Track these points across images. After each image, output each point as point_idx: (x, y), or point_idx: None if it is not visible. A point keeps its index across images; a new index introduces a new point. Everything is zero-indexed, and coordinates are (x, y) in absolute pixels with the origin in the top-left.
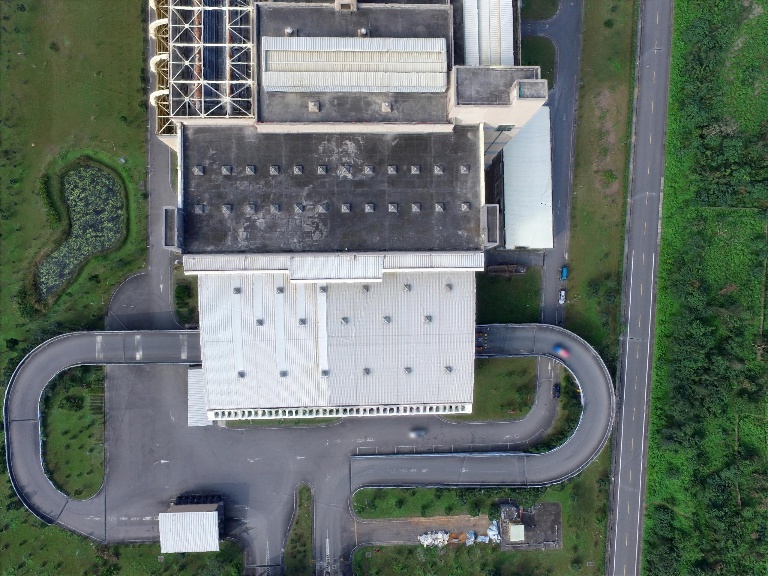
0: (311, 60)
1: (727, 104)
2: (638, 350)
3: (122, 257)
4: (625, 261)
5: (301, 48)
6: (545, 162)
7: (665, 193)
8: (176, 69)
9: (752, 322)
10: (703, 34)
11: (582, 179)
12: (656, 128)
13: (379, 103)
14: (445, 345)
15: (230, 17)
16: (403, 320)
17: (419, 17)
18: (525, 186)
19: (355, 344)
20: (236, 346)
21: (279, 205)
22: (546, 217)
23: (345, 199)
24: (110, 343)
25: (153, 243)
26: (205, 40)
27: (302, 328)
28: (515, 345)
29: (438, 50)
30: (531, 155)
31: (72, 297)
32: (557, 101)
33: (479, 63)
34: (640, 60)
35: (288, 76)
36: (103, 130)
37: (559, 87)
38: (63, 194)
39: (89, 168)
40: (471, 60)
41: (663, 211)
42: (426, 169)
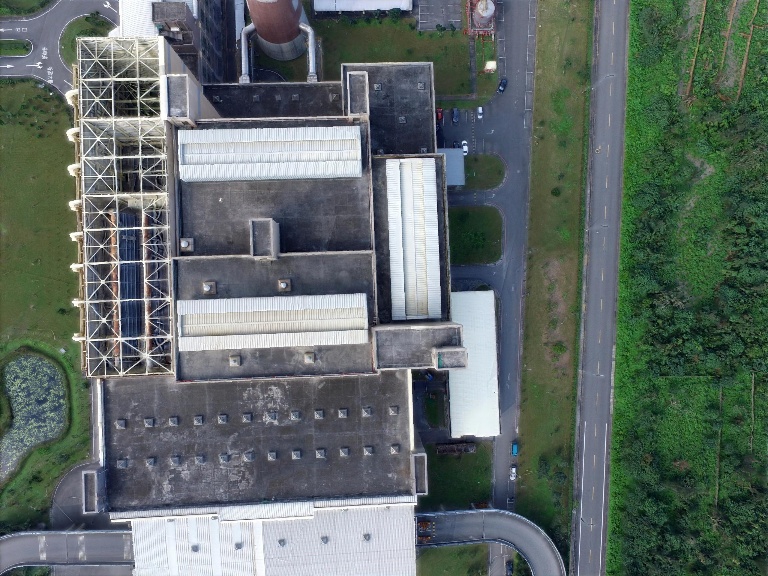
0: (228, 321)
1: (679, 267)
2: (592, 523)
3: (65, 448)
4: (577, 433)
5: (217, 311)
6: (490, 348)
7: (617, 362)
8: (93, 327)
9: (707, 493)
10: (652, 201)
11: (532, 351)
12: (607, 295)
13: (302, 353)
14: (385, 561)
15: (147, 270)
16: (341, 539)
17: (342, 262)
18: (470, 374)
19: (293, 564)
20: (172, 571)
21: (204, 456)
22: (492, 404)
23: (271, 446)
24: (53, 543)
25: (96, 432)
26: (124, 288)
27: (238, 551)
28: (464, 532)
29: (358, 307)
30: (475, 342)
31: (16, 491)
32: (505, 272)
33: (406, 302)
34: (589, 227)
35: (205, 341)
36: (43, 319)
37: (507, 257)
38: (4, 385)
39: (30, 357)
40: (397, 301)
41: (615, 380)
42: (354, 412)
